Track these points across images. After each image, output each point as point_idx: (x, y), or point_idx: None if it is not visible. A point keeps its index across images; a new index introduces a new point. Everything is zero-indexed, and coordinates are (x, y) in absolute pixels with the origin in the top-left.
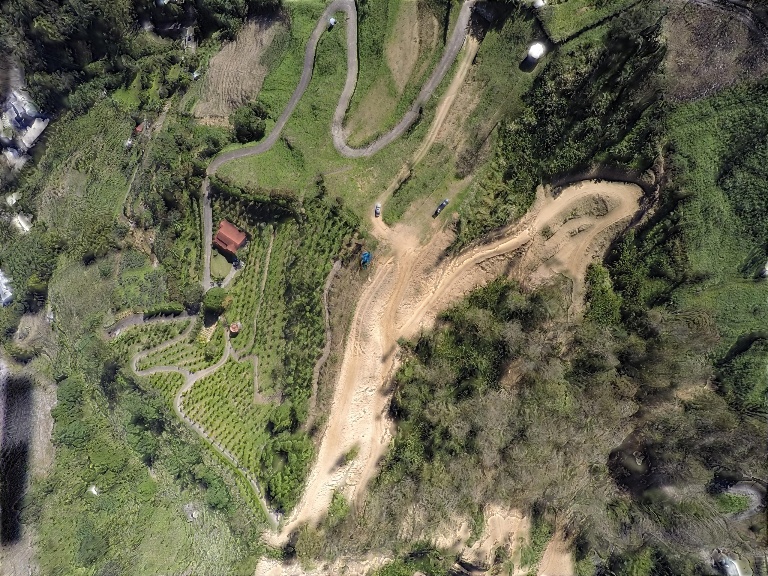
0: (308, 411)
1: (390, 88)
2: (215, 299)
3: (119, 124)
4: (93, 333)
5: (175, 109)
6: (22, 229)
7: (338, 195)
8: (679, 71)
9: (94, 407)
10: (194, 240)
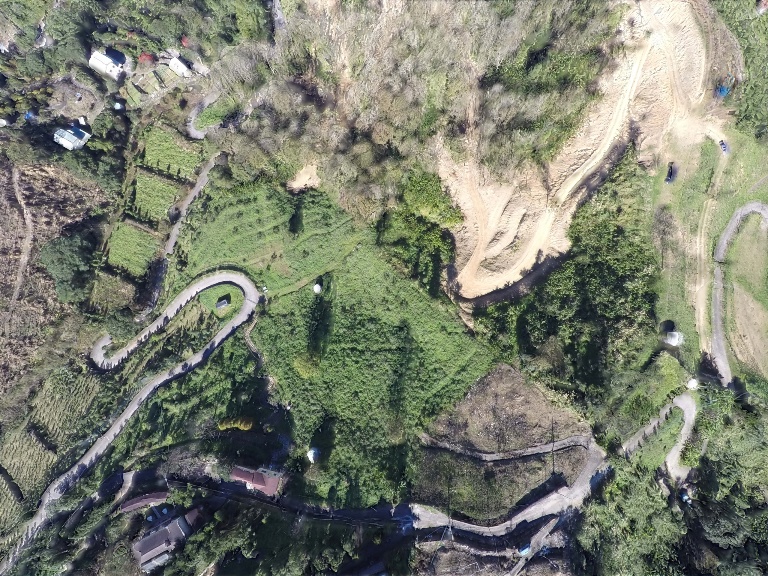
0: None
1: (747, 283)
2: None
3: None
4: None
5: None
6: None
7: (760, 151)
8: (512, 391)
9: None
10: None
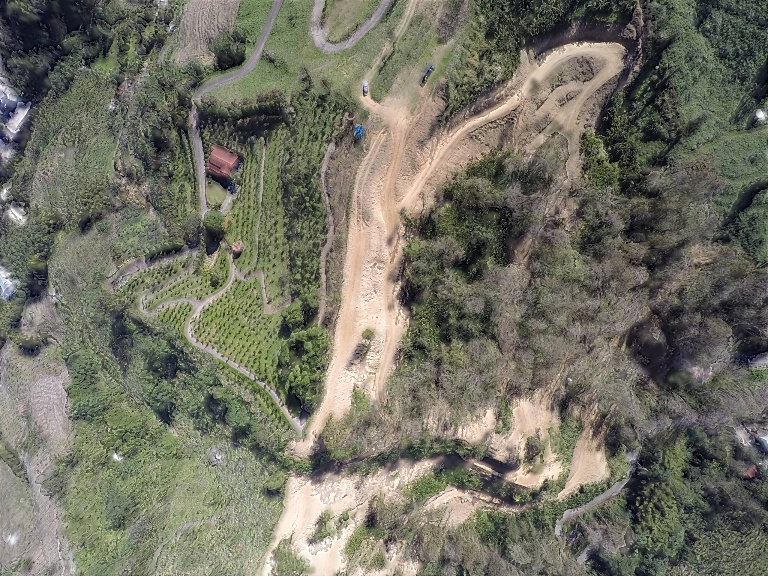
0: (319, 296)
1: None
2: (214, 219)
3: (101, 92)
4: (96, 285)
5: (154, 62)
6: (15, 219)
7: None
8: None
9: (106, 377)
10: (187, 175)
